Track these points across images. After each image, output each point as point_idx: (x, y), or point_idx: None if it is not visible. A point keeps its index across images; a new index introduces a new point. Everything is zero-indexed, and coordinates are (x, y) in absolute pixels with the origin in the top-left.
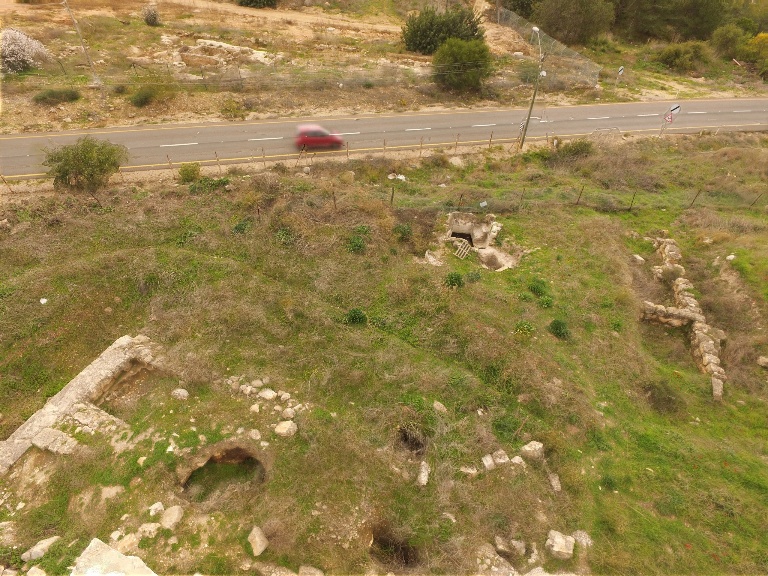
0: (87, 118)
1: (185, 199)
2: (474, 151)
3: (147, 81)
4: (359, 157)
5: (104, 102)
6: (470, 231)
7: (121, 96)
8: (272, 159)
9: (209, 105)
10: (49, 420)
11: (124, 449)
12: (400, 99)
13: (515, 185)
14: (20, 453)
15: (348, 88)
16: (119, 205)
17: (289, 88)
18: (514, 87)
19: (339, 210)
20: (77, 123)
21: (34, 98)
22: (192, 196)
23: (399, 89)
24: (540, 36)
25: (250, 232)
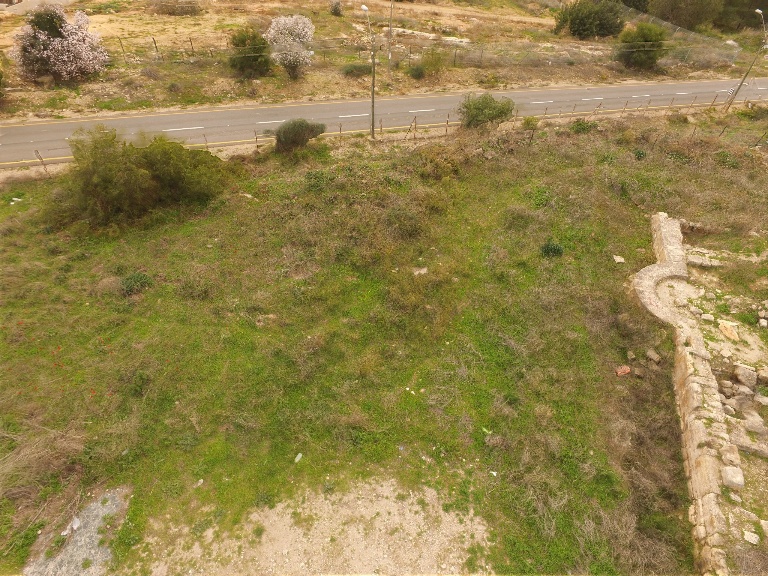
0: (387, 88)
1: (576, 137)
2: (698, 111)
3: (528, 49)
4: (624, 115)
5: (392, 75)
6: (765, 161)
7: (398, 71)
8: (565, 116)
9: (466, 78)
10: (679, 252)
11: (760, 260)
12: (599, 74)
13: (762, 132)
14: (685, 268)
15: (558, 65)
16: (536, 141)
17: (515, 65)
18: (674, 65)
19: (693, 143)
20: (383, 91)
21: (345, 71)
22: (578, 135)
23: (593, 66)
24: (764, 17)
25: (650, 156)
